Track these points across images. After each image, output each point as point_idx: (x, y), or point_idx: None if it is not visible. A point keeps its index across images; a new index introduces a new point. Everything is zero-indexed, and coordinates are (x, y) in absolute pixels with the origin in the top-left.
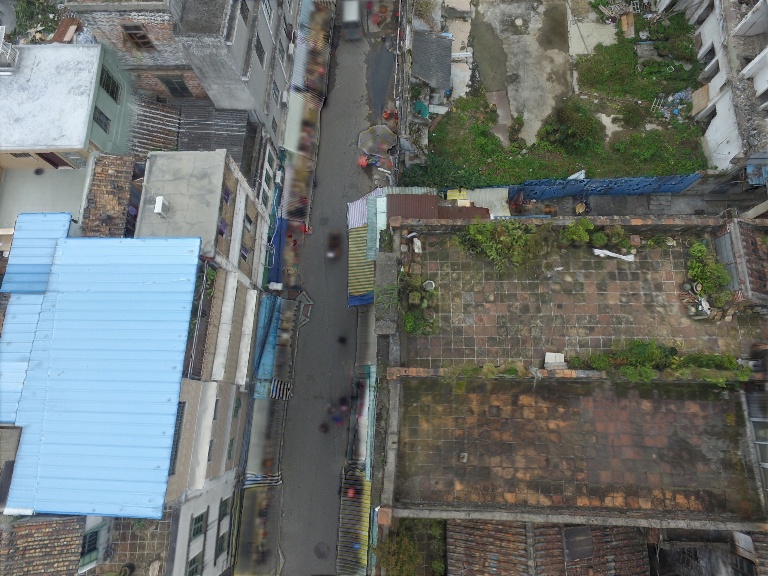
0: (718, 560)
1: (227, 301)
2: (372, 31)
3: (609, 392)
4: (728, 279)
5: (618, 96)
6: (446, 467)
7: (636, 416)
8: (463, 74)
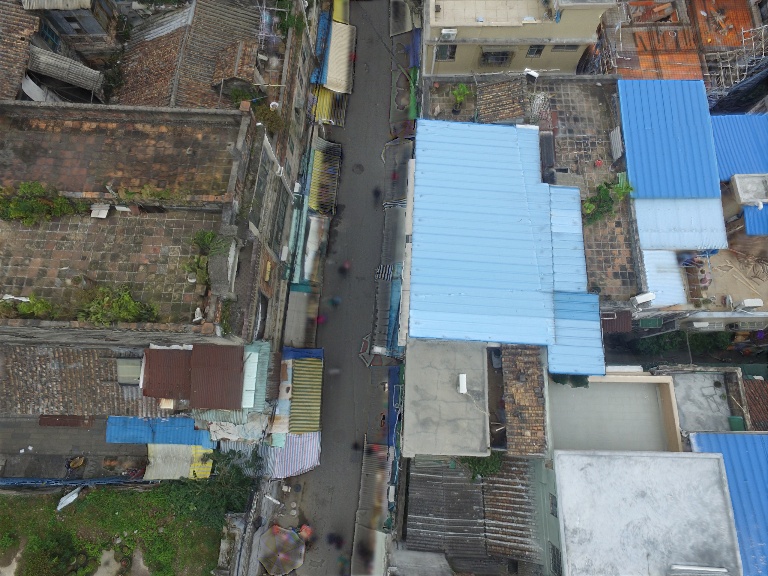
0: None
1: (407, 311)
2: None
3: None
4: None
5: None
6: (206, 149)
7: (53, 178)
8: None
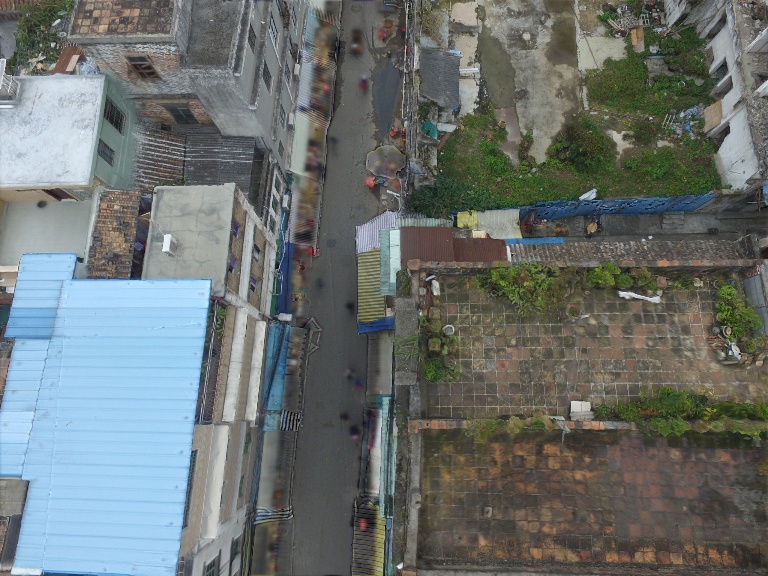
0: None
1: (237, 338)
2: (377, 47)
3: (637, 440)
4: (760, 324)
5: (629, 112)
6: (469, 521)
7: (665, 466)
8: (471, 90)
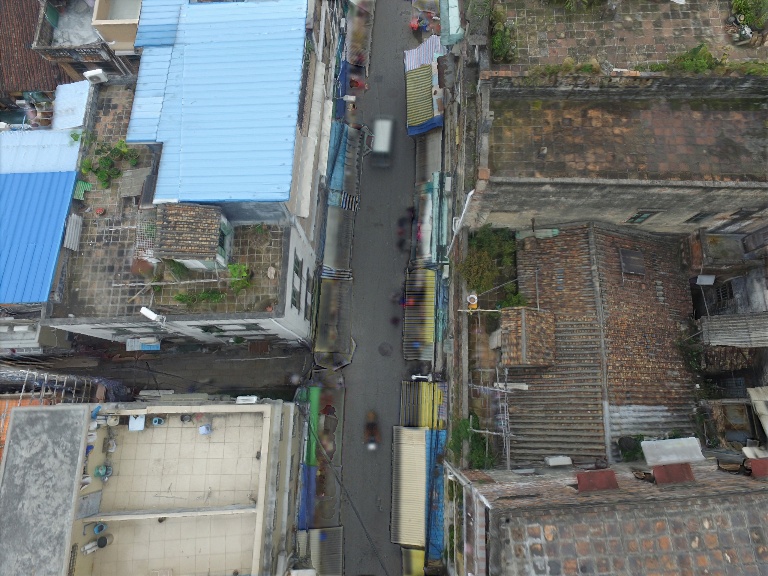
0: (753, 281)
1: (317, 84)
2: None
3: (665, 106)
4: (767, 3)
5: None
6: (528, 163)
7: (688, 123)
8: None
